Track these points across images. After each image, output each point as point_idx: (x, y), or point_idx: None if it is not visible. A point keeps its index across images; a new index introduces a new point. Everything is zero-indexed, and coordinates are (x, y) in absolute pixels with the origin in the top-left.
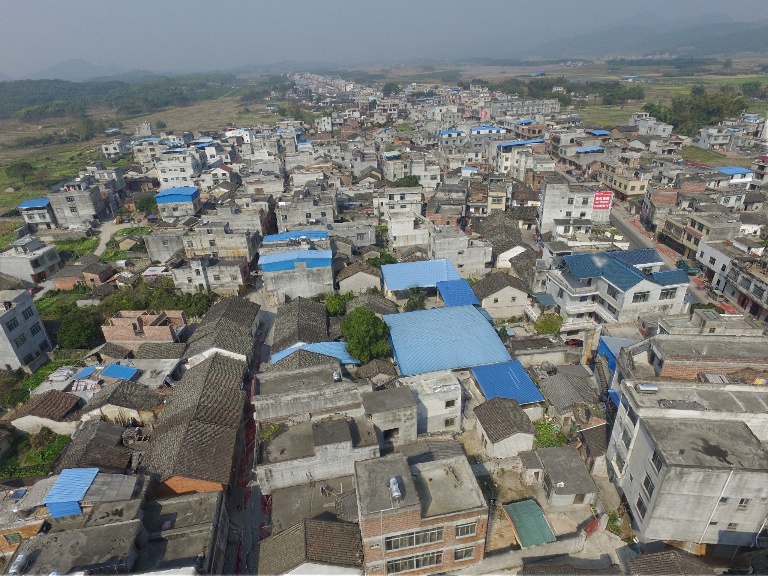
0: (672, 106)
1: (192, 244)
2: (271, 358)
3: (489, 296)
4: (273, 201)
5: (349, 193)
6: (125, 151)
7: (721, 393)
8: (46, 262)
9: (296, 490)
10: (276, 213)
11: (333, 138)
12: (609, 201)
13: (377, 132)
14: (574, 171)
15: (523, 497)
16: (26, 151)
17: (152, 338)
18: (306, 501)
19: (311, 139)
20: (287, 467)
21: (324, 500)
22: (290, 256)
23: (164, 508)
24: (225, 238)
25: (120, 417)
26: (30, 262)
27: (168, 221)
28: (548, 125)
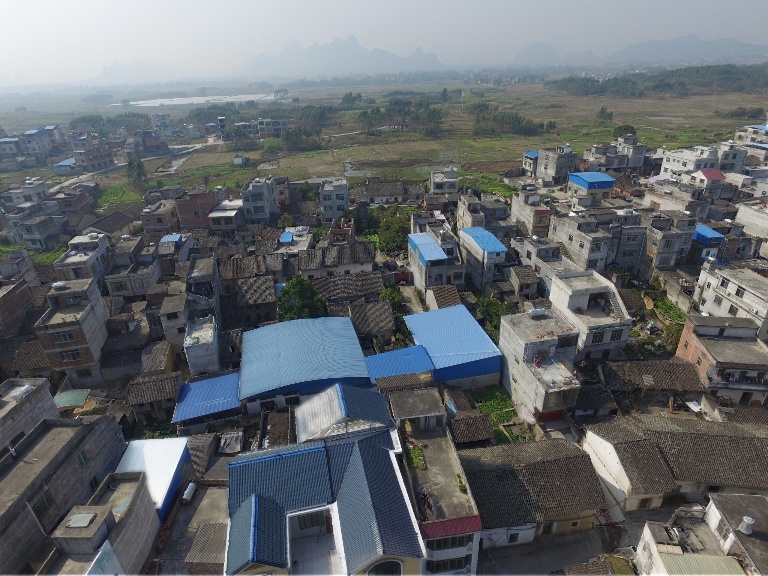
0: None
1: None
2: None
3: None
4: None
5: None
6: None
7: None
8: (446, 188)
9: None
10: (551, 220)
11: None
12: None
13: None
14: None
15: None
16: (721, 121)
17: None
18: None
19: None
20: None
21: None
22: (422, 241)
23: None
24: None
25: None
26: (434, 183)
27: (561, 200)
28: None
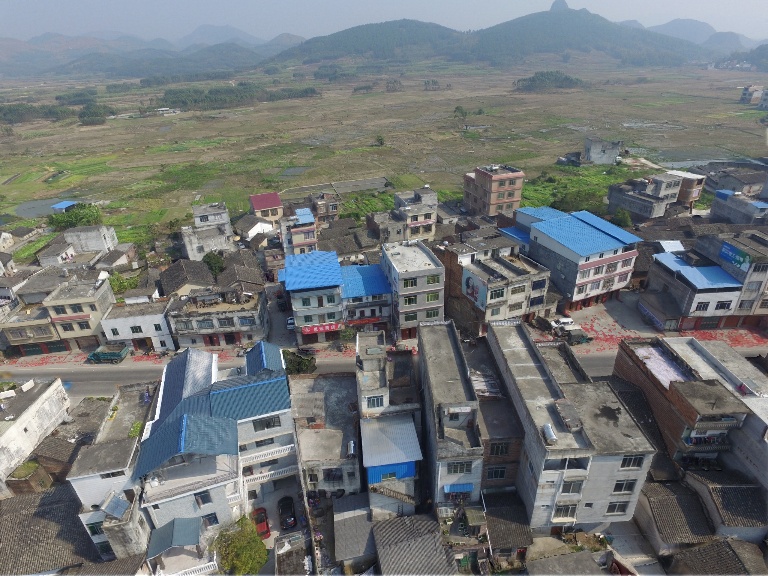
0: None
1: None
2: None
3: None
4: None
5: None
6: None
7: (519, 384)
8: None
9: None
10: None
11: None
12: None
13: None
14: None
15: None
16: None
17: None
18: None
19: None
20: None
21: None
22: None
23: None
24: None
25: None
26: None
27: None
28: None
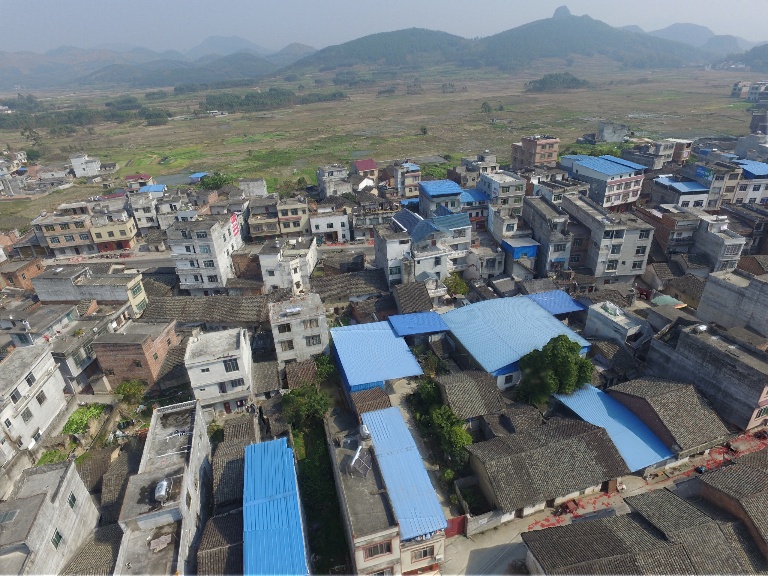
0: None
1: None
2: None
3: None
4: None
5: None
6: None
7: None
8: None
9: None
10: None
11: None
12: (237, 224)
13: None
14: None
15: (637, 314)
16: None
17: None
18: None
19: None
20: None
21: None
22: (408, 464)
23: None
24: None
25: None
26: None
27: None
28: None
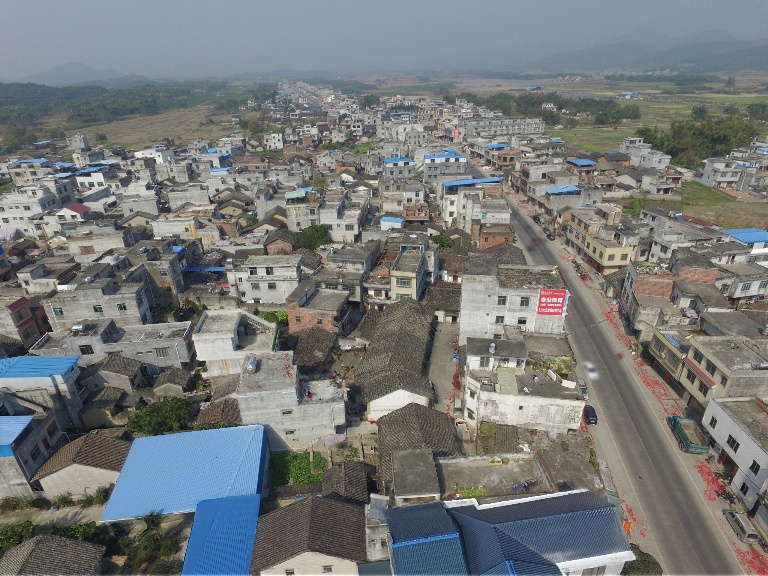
0: (670, 131)
1: None
2: None
3: (273, 566)
4: None
5: (228, 249)
6: None
7: None
8: None
9: None
10: (43, 305)
11: (263, 162)
12: (562, 304)
13: (321, 155)
14: (543, 216)
15: None
16: None
17: None
18: None
19: (236, 163)
20: None
21: None
22: None
23: None
24: None
25: None
26: None
27: None
28: (522, 151)
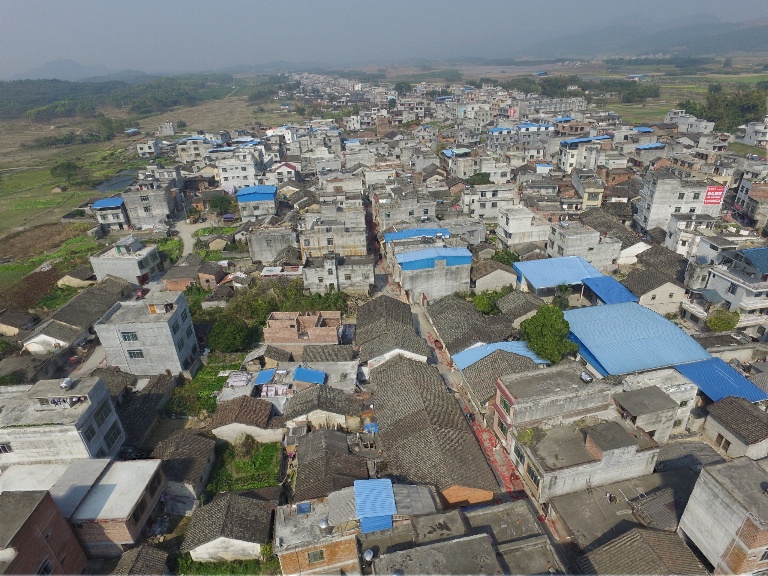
0: (707, 103)
1: (309, 243)
2: (452, 359)
3: (648, 293)
4: (364, 199)
5: None
6: (159, 150)
7: None
8: (149, 263)
9: (576, 497)
10: (379, 211)
11: (376, 136)
12: (721, 196)
13: (417, 130)
14: (633, 168)
15: None
16: (49, 151)
17: (315, 340)
18: (595, 509)
19: (354, 137)
20: (571, 473)
21: (614, 507)
22: (429, 254)
23: (472, 520)
24: (344, 236)
25: (326, 423)
26: (137, 263)
27: (250, 220)
28: (590, 122)
